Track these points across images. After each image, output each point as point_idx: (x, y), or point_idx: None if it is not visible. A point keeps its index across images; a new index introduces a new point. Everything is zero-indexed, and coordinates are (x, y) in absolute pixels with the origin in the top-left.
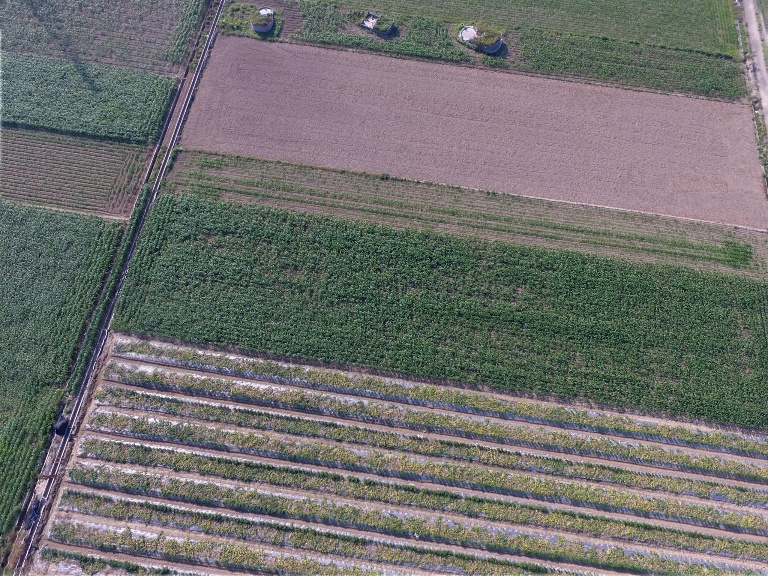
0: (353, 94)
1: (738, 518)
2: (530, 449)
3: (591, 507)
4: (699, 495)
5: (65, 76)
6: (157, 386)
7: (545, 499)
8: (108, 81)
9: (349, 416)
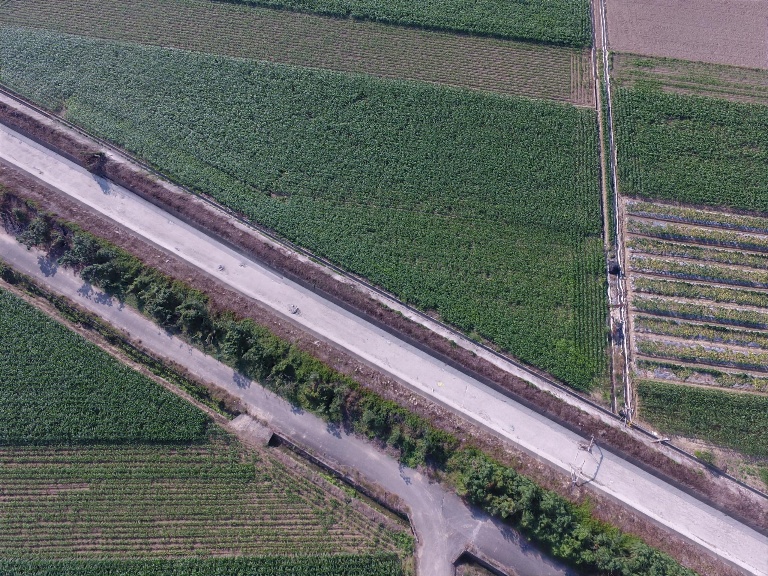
0: (739, 7)
1: None
2: None
3: None
4: None
5: None
6: (675, 237)
7: None
8: None
9: None
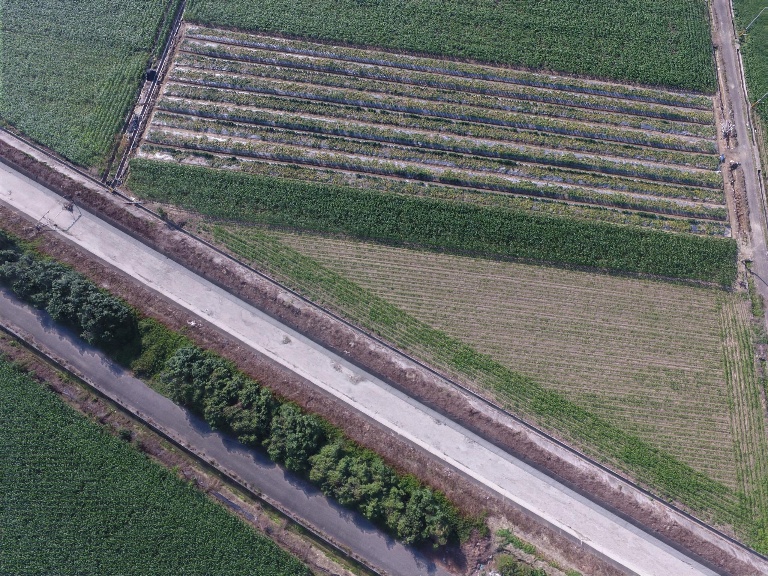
0: None
1: (661, 138)
2: (505, 98)
3: (551, 131)
4: (633, 125)
5: None
6: (221, 55)
7: (516, 126)
8: None
9: (368, 75)
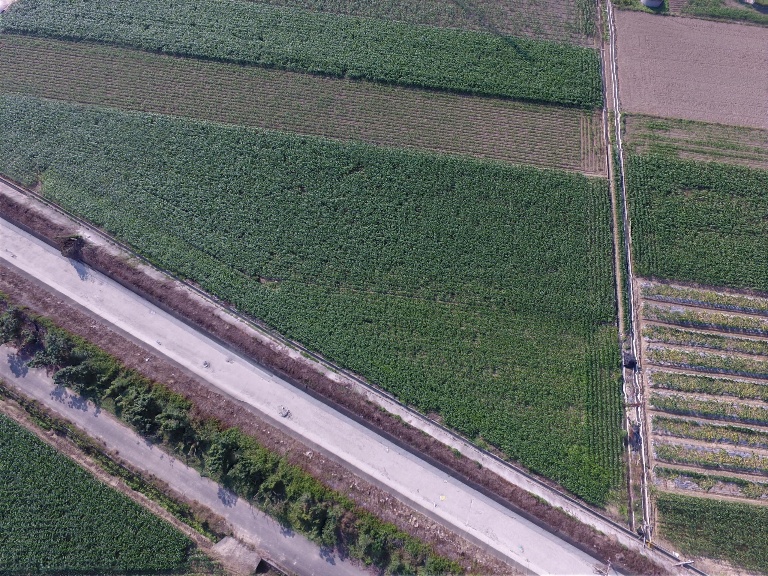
0: (758, 62)
1: None
2: None
3: None
4: None
5: (499, 48)
6: (694, 324)
7: None
8: (540, 52)
9: None
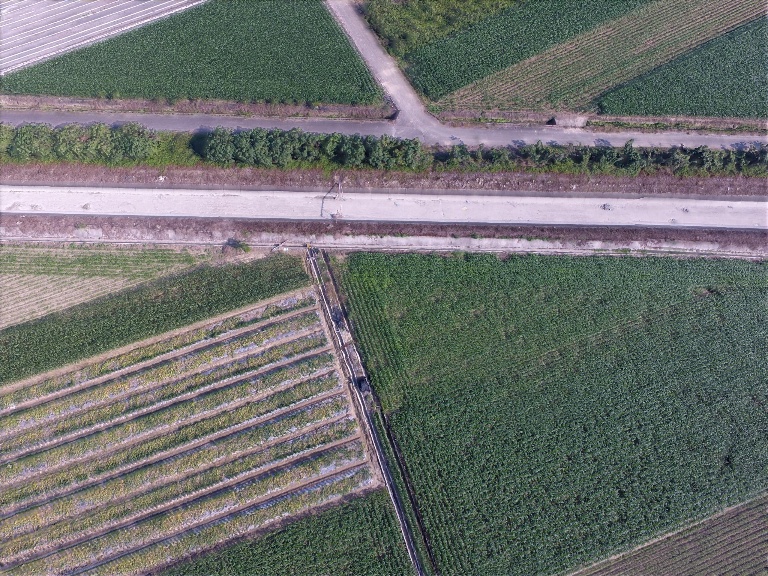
0: None
1: None
2: None
3: None
4: None
5: None
6: (307, 460)
7: None
8: None
9: (107, 537)
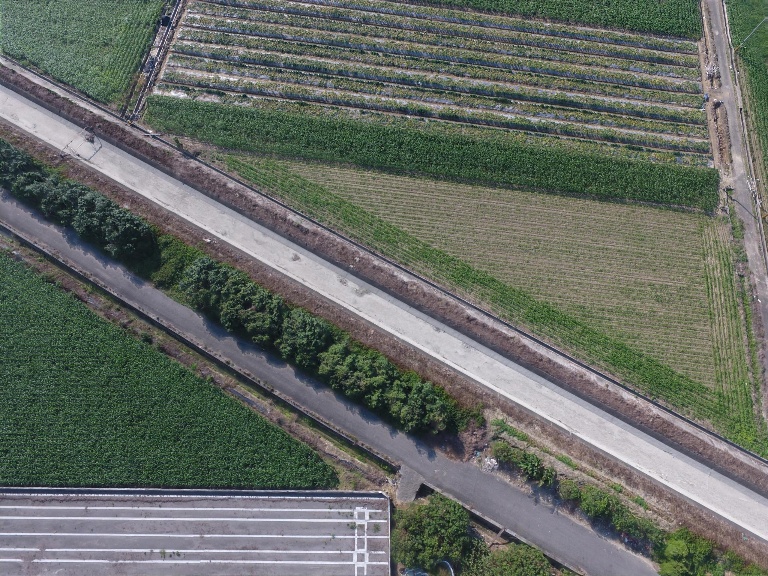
0: None
1: (649, 79)
2: None
3: (544, 73)
4: (622, 67)
5: None
6: (231, 3)
7: (511, 68)
8: None
9: (371, 22)
